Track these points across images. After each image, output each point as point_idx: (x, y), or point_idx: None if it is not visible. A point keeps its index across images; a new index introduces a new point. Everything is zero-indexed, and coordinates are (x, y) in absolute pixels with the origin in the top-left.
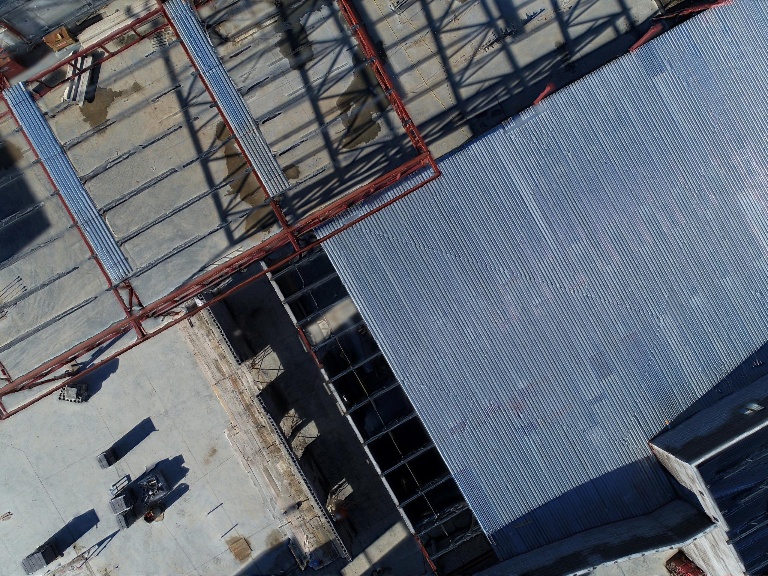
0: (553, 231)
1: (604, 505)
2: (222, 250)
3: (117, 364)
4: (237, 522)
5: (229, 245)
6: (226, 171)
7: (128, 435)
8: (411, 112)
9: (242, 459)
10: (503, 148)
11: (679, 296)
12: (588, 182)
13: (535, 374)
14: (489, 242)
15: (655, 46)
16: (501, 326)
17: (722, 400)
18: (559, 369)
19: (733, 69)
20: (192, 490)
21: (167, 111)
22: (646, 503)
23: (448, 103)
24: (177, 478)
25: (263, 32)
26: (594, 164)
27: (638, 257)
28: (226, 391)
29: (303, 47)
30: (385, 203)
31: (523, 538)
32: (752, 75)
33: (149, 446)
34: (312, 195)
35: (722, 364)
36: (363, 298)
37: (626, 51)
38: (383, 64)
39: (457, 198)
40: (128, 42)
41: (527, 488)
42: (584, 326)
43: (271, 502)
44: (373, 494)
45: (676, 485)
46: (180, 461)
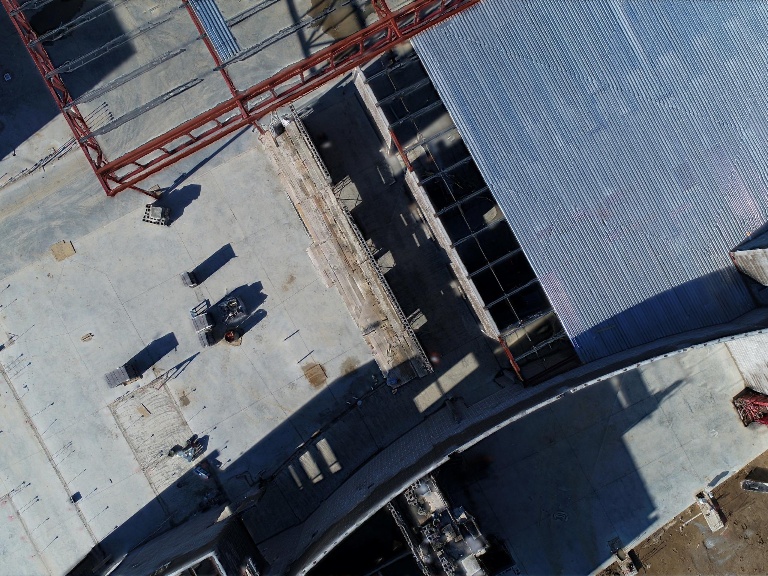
0: (641, 43)
1: (685, 312)
2: None
3: (199, 191)
4: (313, 349)
5: None
6: (310, 4)
7: (208, 261)
8: None
9: (328, 268)
10: None
11: (762, 111)
12: None
13: (620, 182)
14: (578, 52)
15: None
16: (588, 134)
17: None
18: (644, 178)
19: None
20: (270, 316)
21: None
22: (726, 312)
23: None
24: (255, 304)
25: None
26: None
27: (723, 71)
28: (309, 210)
29: None
30: None
31: (605, 342)
32: None
33: (229, 270)
34: None
35: None
36: (454, 103)
37: None
38: None
39: (548, 8)
40: None
41: (610, 293)
42: (669, 137)
43: (356, 310)
44: (447, 325)
45: (757, 292)
46: (258, 287)
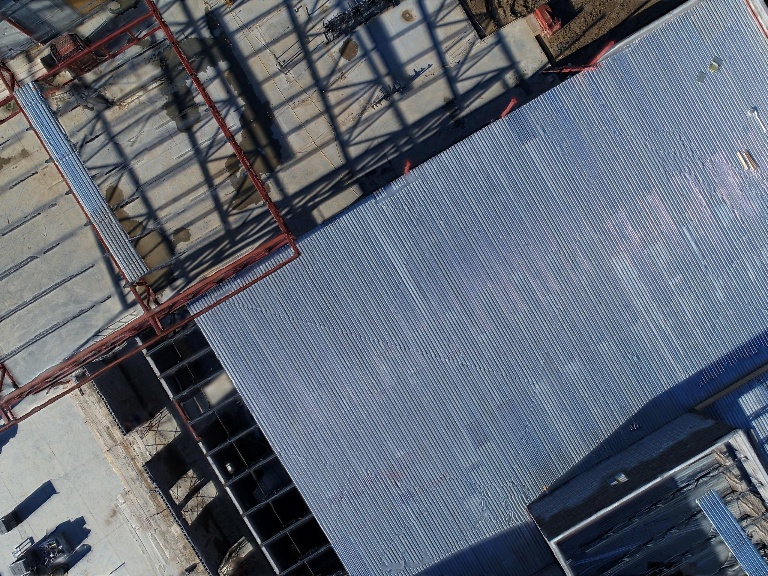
0: (427, 300)
1: (483, 570)
2: (116, 314)
3: (16, 429)
4: None
5: (122, 309)
6: None
7: (29, 498)
8: (300, 172)
9: (130, 528)
10: (375, 218)
11: (555, 362)
12: (461, 250)
13: (412, 443)
14: (363, 313)
15: (527, 111)
16: (377, 396)
17: (599, 465)
18: (435, 437)
19: (607, 132)
20: (94, 550)
21: (56, 177)
22: (524, 567)
23: (337, 162)
24: (79, 539)
25: (149, 95)
26: (467, 232)
27: (513, 324)
28: (118, 457)
29: (190, 109)
30: (244, 286)
31: None
32: (627, 138)
33: (49, 509)
34: (203, 258)
35: (599, 429)
36: (238, 372)
37: (516, 105)
38: (271, 124)
39: (330, 270)
40: (15, 108)
41: None
42: (460, 394)
43: (160, 569)
44: None
45: None
46: (81, 522)
